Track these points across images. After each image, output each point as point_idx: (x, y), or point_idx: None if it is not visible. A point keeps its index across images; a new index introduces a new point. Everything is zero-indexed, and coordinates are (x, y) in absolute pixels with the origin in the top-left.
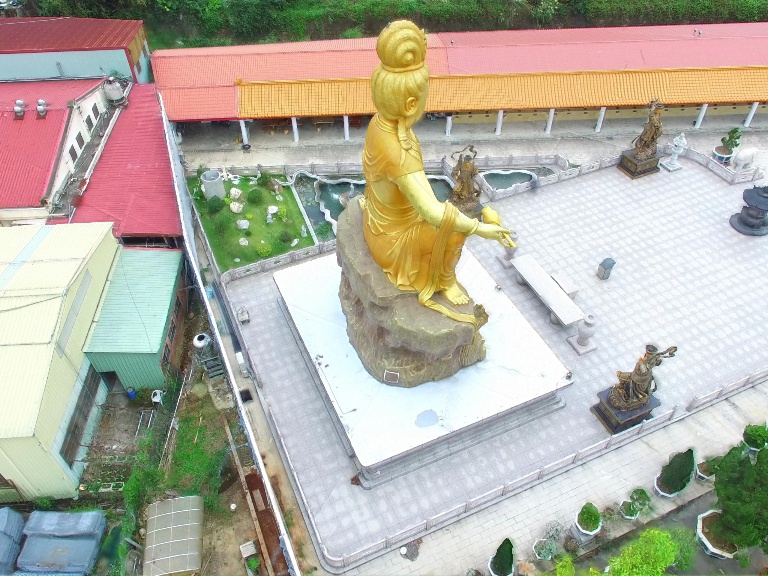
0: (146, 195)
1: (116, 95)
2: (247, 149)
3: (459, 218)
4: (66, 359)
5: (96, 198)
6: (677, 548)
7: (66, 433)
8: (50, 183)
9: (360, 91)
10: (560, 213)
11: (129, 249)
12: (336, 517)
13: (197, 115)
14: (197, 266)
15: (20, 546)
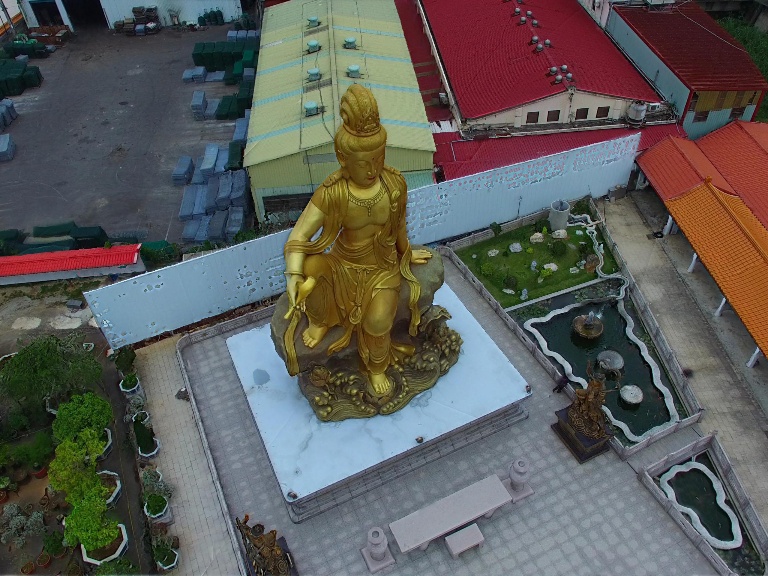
0: (494, 166)
1: (633, 114)
2: (655, 236)
3: (289, 254)
4: (308, 168)
5: (491, 146)
6: (88, 547)
7: (276, 195)
8: (485, 115)
9: (763, 283)
10: (640, 570)
11: (433, 176)
12: (216, 347)
13: (652, 174)
14: (443, 225)
15: (225, 209)
